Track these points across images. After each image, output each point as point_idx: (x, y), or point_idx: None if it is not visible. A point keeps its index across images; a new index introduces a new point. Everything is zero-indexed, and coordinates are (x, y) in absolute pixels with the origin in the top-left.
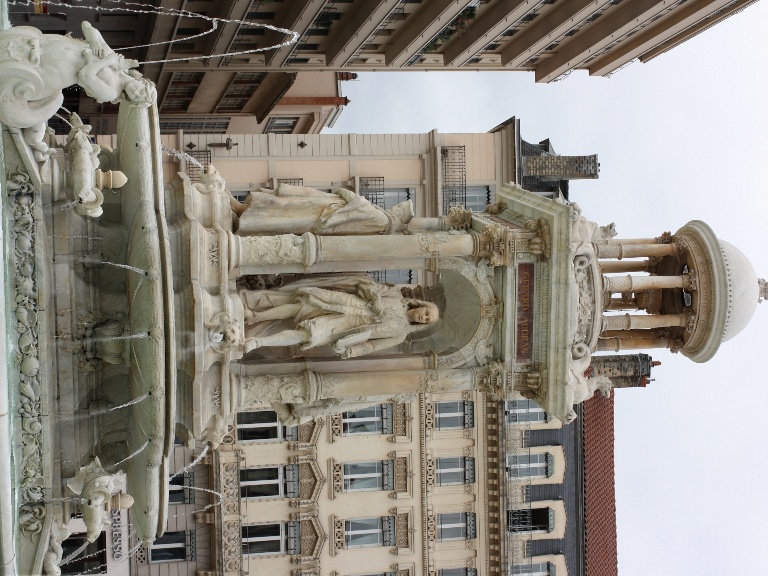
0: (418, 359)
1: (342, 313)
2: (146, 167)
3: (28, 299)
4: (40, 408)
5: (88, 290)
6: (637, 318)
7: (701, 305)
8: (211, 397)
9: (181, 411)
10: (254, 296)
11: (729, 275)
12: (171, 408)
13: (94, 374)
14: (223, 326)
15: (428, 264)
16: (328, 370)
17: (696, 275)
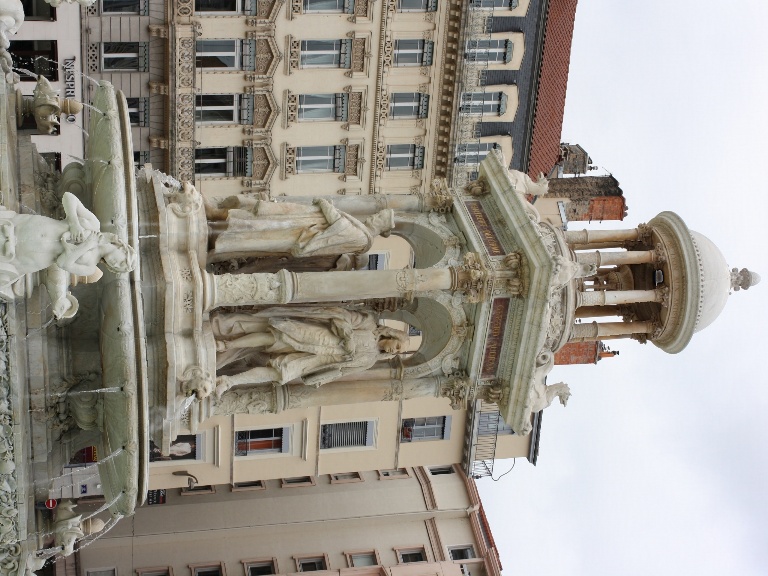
0: (385, 370)
1: (314, 354)
2: None
3: (3, 416)
4: (16, 498)
5: (61, 354)
6: (605, 328)
7: (669, 319)
8: (180, 417)
9: (151, 430)
10: (227, 323)
11: (702, 292)
12: (143, 493)
13: (67, 426)
14: (195, 381)
15: (404, 293)
16: (296, 381)
17: (670, 293)
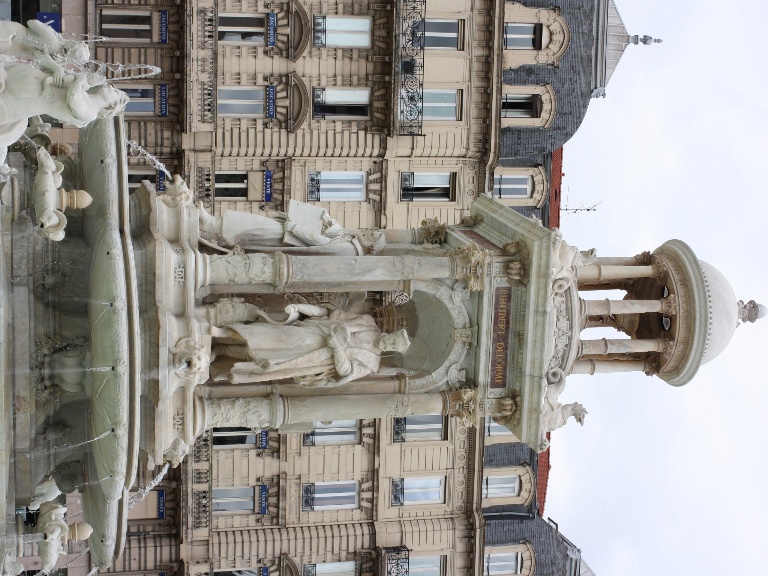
0: None
1: None
2: None
3: None
4: None
5: None
6: None
7: None
8: None
9: None
10: None
11: None
12: None
13: None
14: (171, 455)
15: None
16: None
17: None
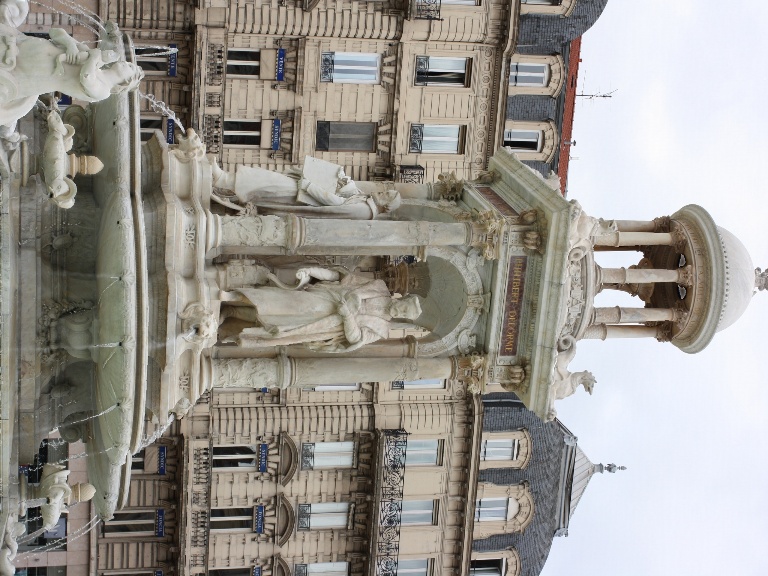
0: None
1: None
2: None
3: None
4: None
5: None
6: None
7: None
8: None
9: None
10: None
11: None
12: None
13: None
14: (176, 407)
15: None
16: None
17: None
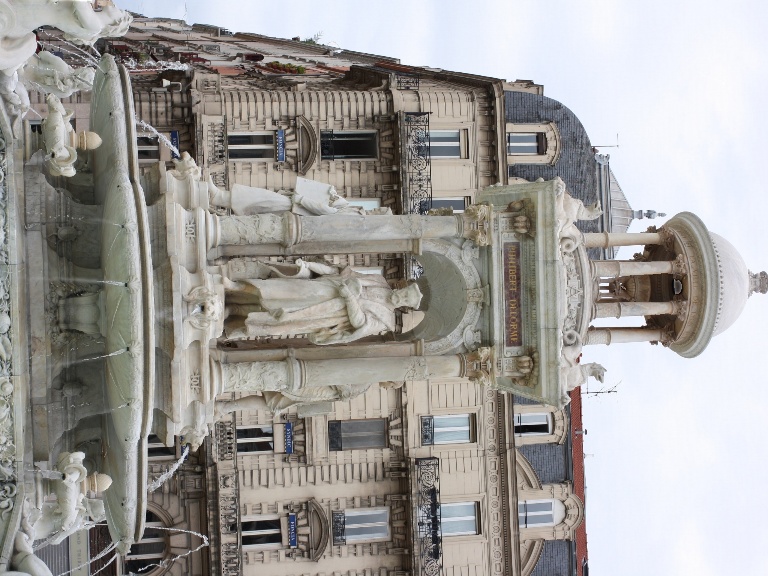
0: None
1: None
2: (133, 447)
3: None
4: None
5: (64, 442)
6: None
7: None
8: None
9: None
10: None
11: None
12: None
13: None
14: (191, 436)
15: None
16: None
17: None
